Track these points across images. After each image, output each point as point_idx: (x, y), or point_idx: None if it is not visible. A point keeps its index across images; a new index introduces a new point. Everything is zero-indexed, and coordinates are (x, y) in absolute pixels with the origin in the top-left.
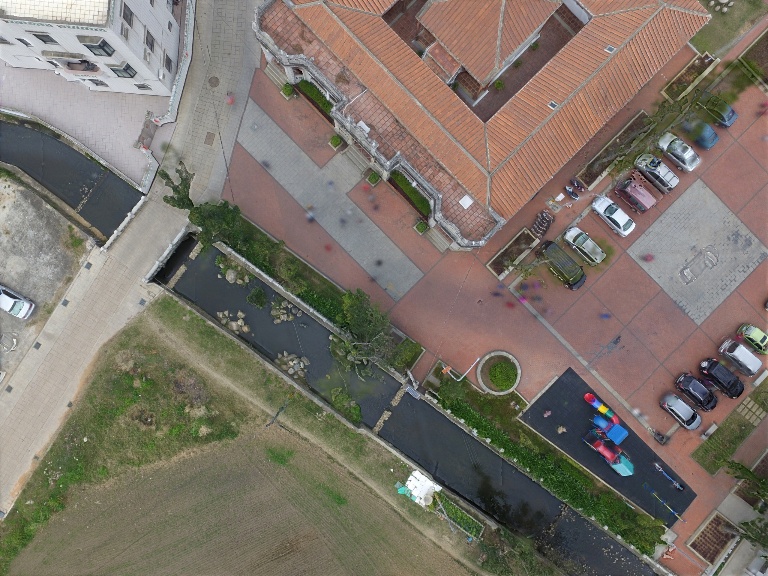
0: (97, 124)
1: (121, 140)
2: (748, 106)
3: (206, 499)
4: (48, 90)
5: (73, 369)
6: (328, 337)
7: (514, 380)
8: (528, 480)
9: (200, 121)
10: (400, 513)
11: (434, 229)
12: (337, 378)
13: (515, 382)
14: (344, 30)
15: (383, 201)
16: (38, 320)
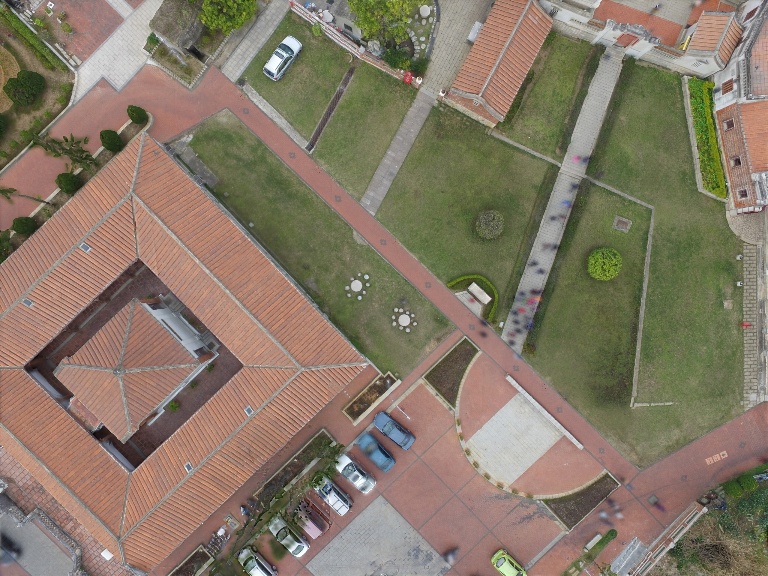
0: None
1: None
2: (432, 424)
3: None
4: None
5: None
6: None
7: None
8: None
9: None
10: None
11: None
12: None
13: None
14: None
15: None
16: None
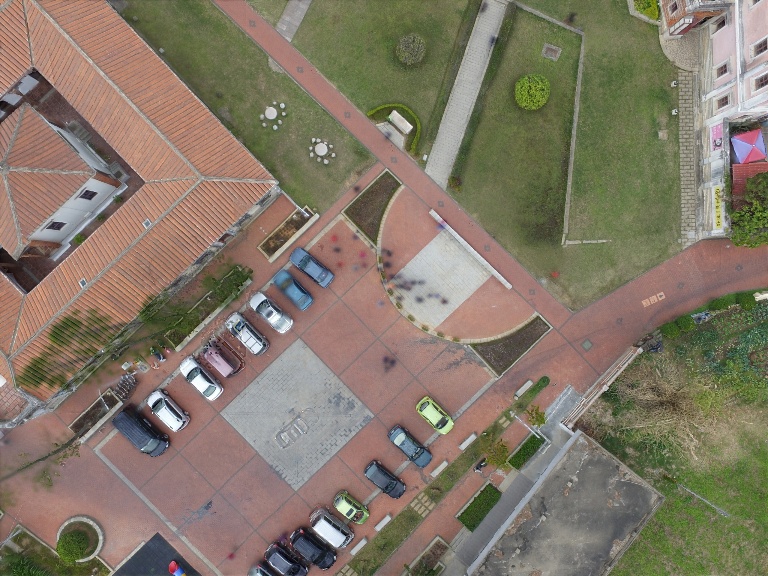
0: None
1: None
2: (353, 263)
3: None
4: None
5: None
6: None
7: (79, 553)
8: None
9: None
10: None
11: None
12: None
13: (96, 549)
14: None
15: None
16: None
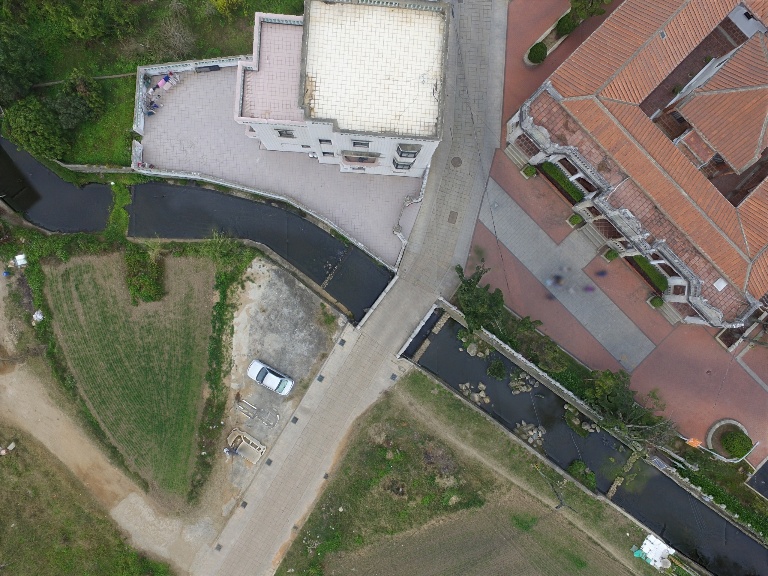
0: (347, 204)
1: (369, 220)
2: None
3: (454, 564)
4: (300, 172)
5: (328, 442)
6: (563, 406)
7: None
8: (751, 541)
9: (443, 200)
10: (636, 575)
11: (668, 303)
12: (571, 446)
13: None
14: (614, 123)
15: (617, 276)
16: (295, 395)
